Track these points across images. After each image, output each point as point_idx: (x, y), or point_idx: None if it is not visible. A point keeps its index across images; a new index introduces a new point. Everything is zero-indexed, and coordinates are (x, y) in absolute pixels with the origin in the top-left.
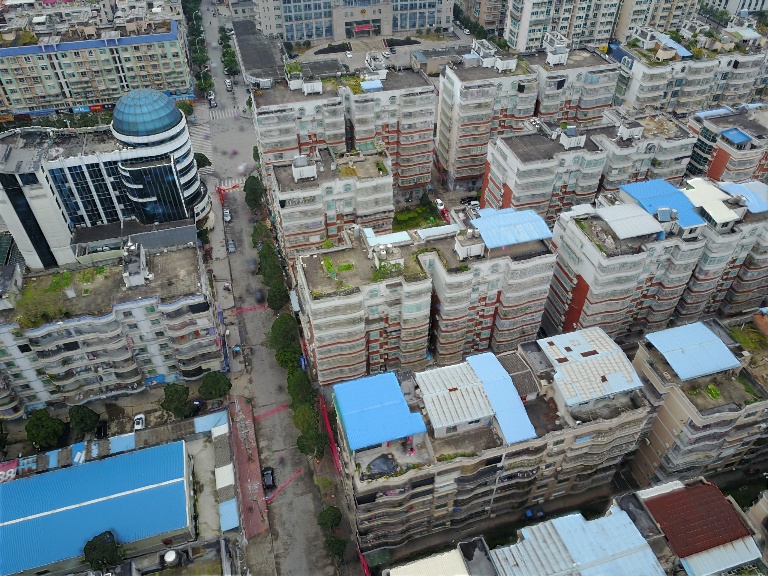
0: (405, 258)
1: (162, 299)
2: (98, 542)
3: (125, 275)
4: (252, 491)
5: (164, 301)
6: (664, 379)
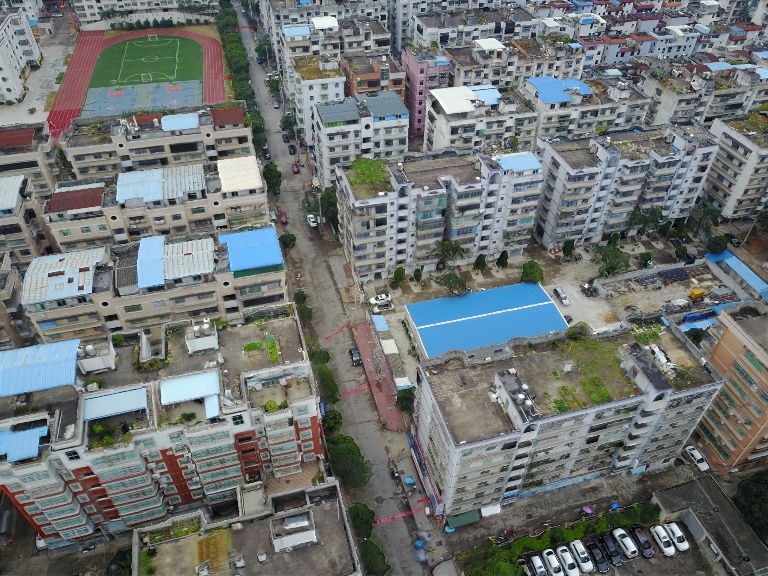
0: (180, 359)
1: (466, 368)
2: (455, 276)
3: (513, 369)
4: (357, 295)
5: (463, 367)
6: (1, 285)
